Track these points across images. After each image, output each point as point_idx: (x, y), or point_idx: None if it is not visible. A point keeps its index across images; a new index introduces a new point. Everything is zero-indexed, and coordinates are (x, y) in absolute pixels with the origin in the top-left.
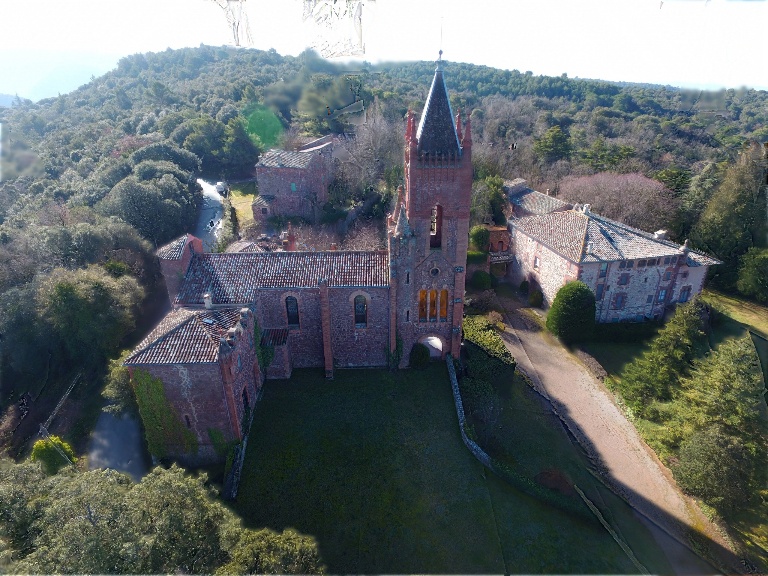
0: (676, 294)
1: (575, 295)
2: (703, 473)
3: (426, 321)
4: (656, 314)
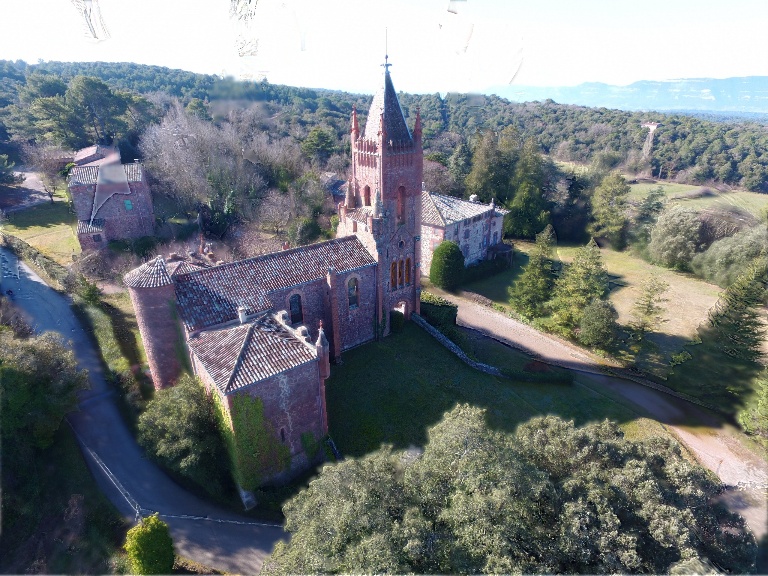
0: (491, 239)
1: (452, 250)
2: (599, 328)
3: (396, 289)
4: (483, 256)
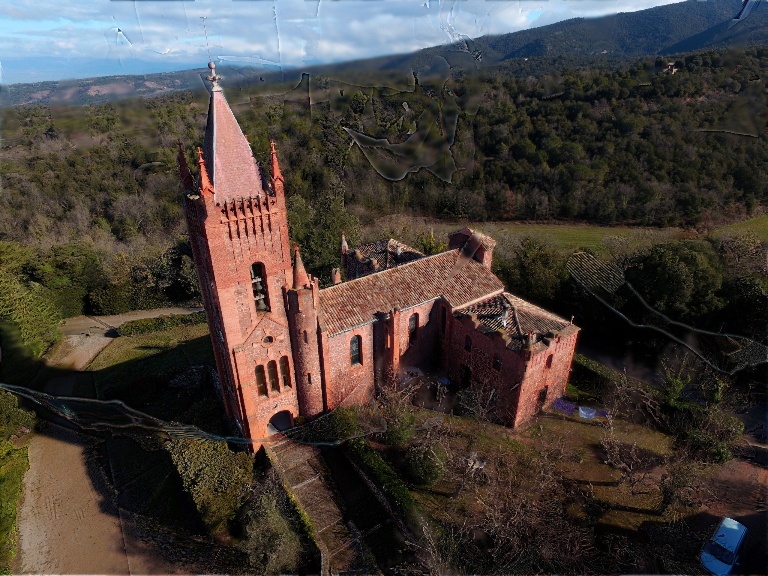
0: None
1: None
2: None
3: None
4: None
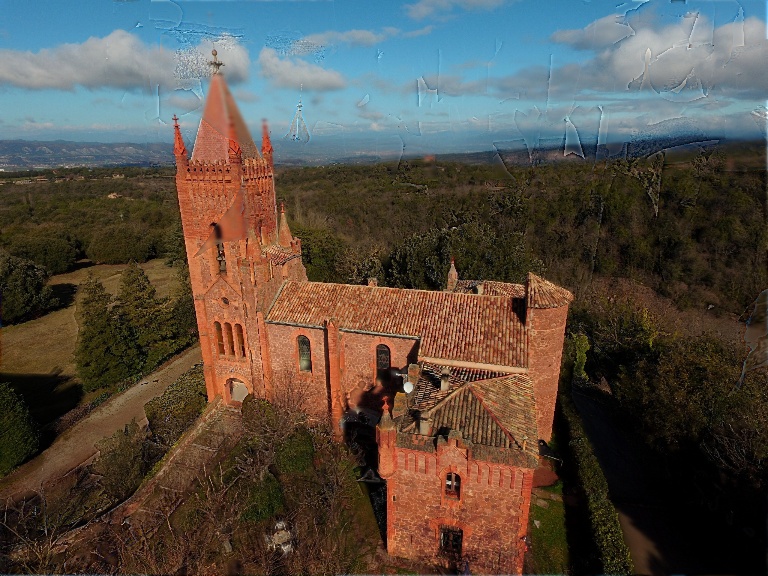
0: None
1: None
2: None
3: None
4: None
